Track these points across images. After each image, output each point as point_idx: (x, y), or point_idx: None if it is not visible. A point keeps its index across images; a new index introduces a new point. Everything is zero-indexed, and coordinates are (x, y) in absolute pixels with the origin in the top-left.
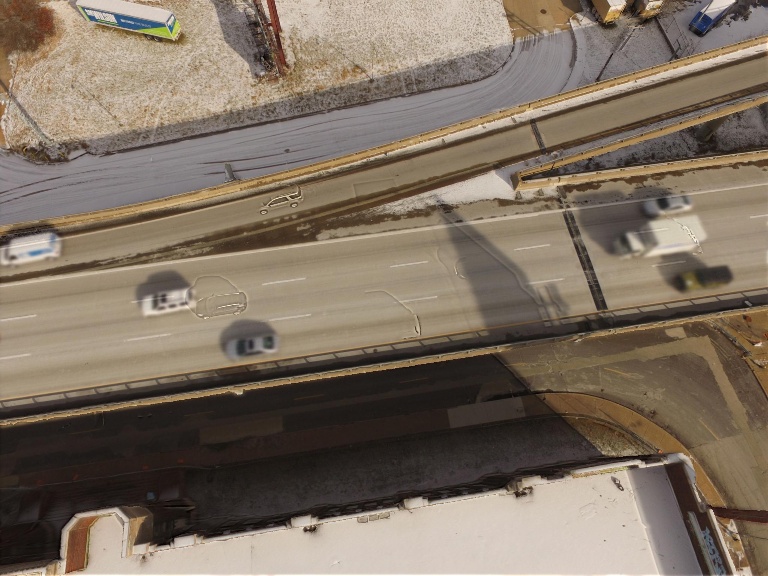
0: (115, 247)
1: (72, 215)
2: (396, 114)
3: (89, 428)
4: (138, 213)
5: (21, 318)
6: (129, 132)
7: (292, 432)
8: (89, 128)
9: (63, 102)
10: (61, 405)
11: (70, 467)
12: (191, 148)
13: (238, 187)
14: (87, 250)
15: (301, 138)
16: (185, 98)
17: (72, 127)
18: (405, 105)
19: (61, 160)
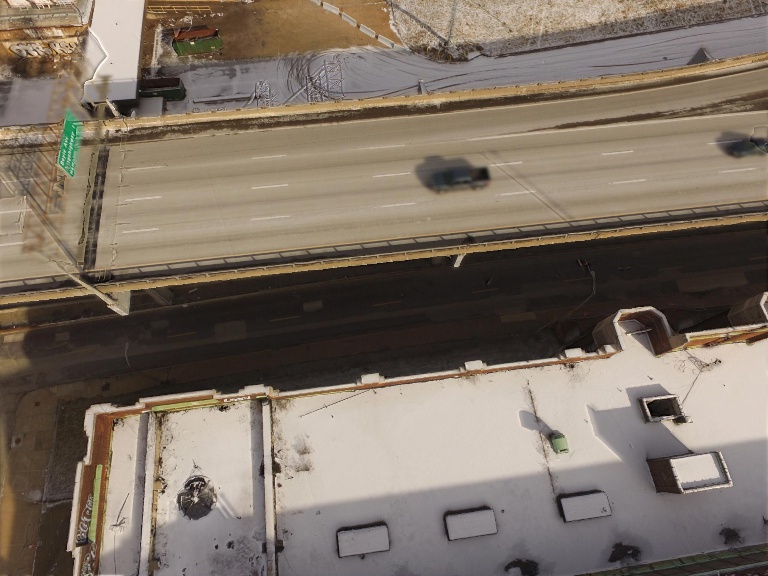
0: (669, 102)
1: (630, 74)
2: (753, 31)
3: (580, 277)
4: (673, 77)
5: (621, 153)
6: (518, 37)
7: (757, 285)
8: (481, 33)
9: (452, 9)
10: (695, 217)
11: (577, 306)
12: (575, 54)
13: (751, 59)
14: (646, 104)
15: (674, 48)
16: (563, 10)
17: (465, 31)
18: (757, 24)
19: (461, 60)
